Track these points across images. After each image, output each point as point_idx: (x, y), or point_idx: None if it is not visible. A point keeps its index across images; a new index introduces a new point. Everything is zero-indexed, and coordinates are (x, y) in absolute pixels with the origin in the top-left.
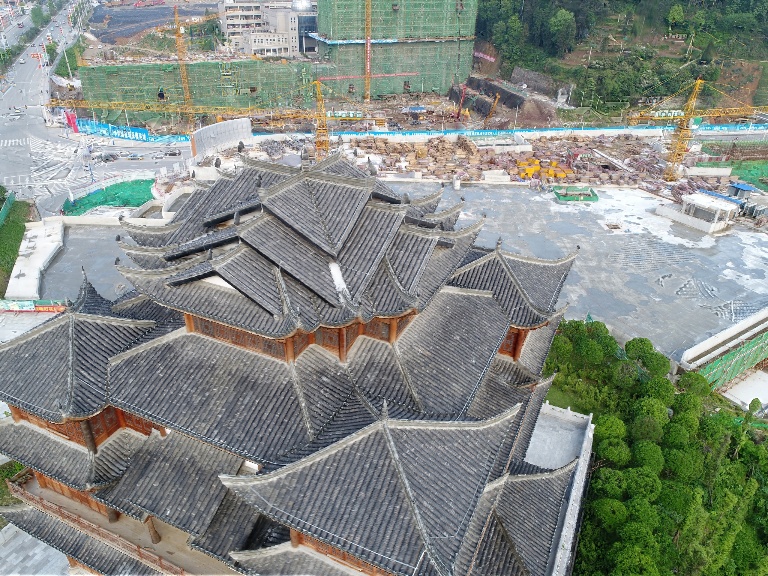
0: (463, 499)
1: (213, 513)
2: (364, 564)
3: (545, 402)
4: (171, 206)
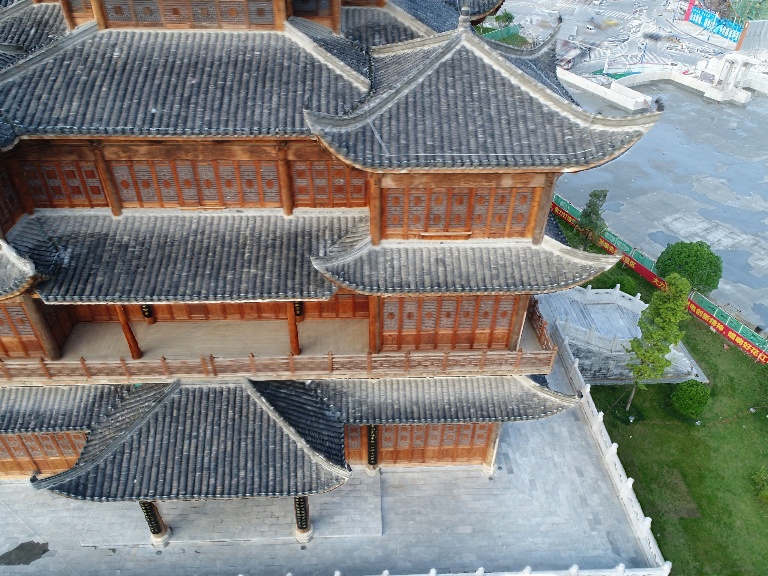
0: None
1: None
2: None
3: (718, 526)
4: (638, 85)
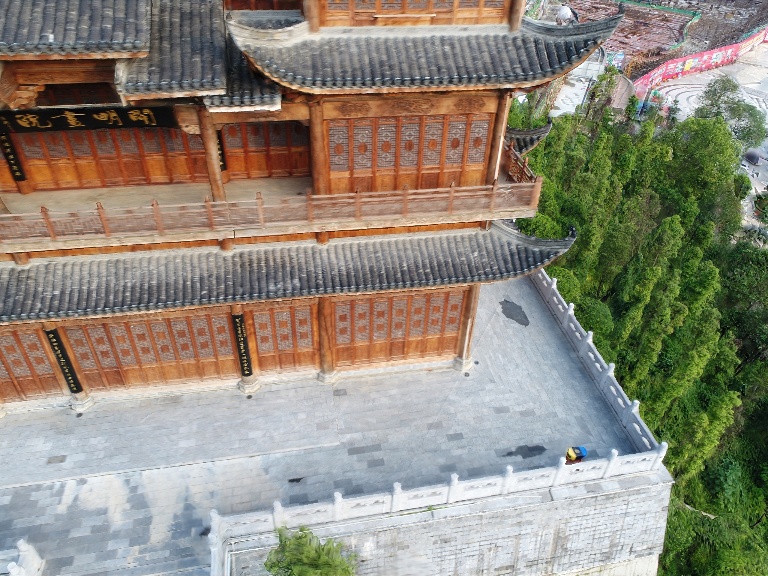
0: None
1: (146, 16)
2: (438, 0)
3: None
4: None
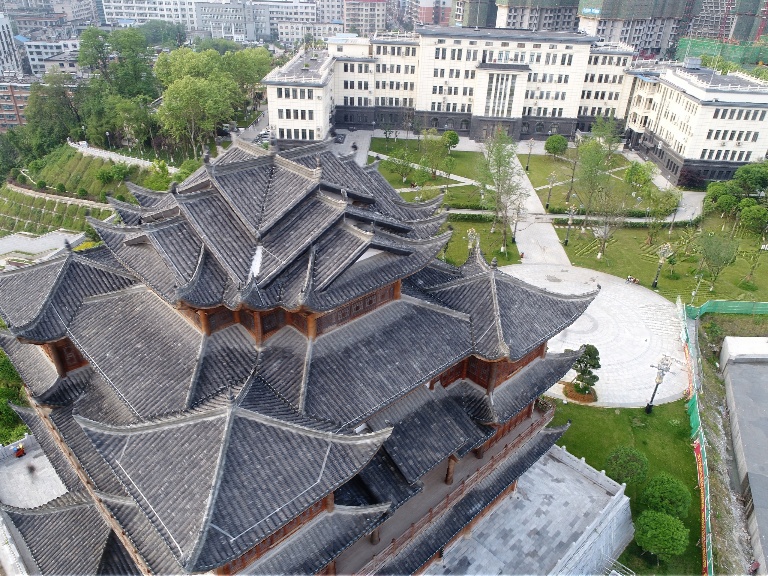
0: (8, 305)
1: None
2: None
3: None
4: None
